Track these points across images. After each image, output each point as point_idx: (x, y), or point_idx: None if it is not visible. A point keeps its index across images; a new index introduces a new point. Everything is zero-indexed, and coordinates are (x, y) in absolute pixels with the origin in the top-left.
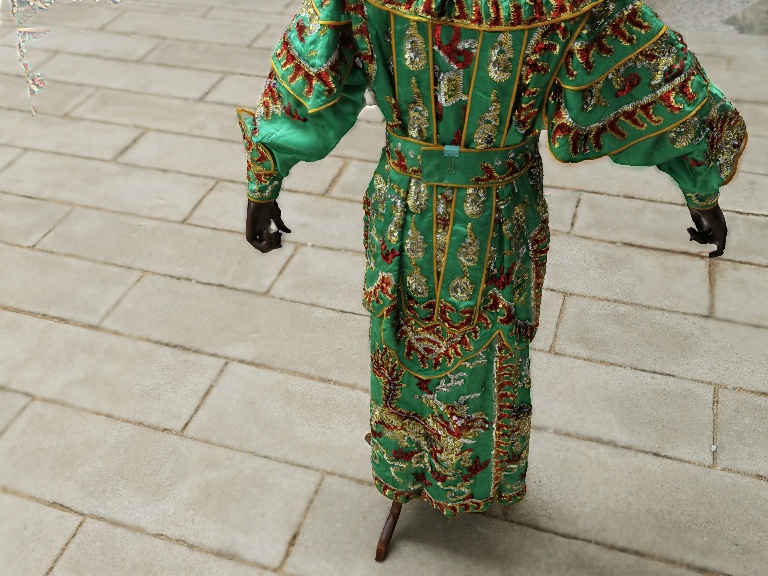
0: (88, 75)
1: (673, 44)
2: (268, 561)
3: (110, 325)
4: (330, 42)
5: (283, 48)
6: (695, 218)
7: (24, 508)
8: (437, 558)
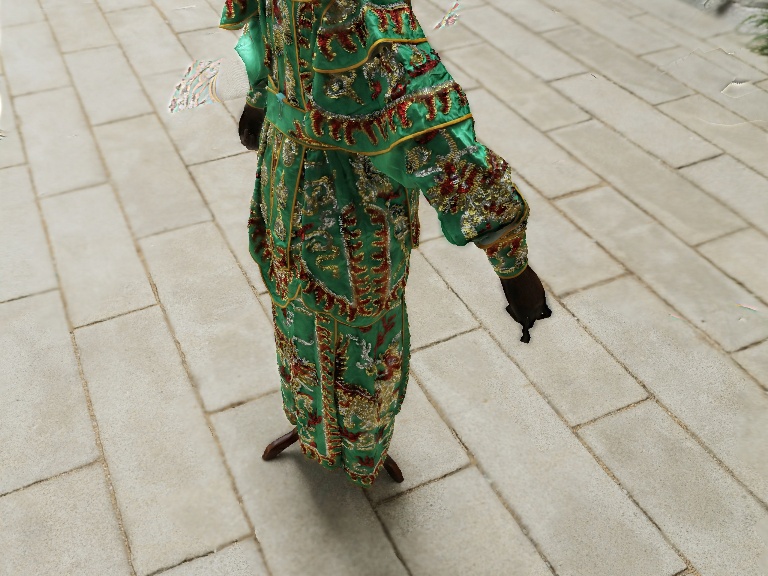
0: (489, 29)
1: (403, 64)
2: (208, 403)
3: None
4: None
5: None
6: None
7: (139, 276)
8: (298, 488)
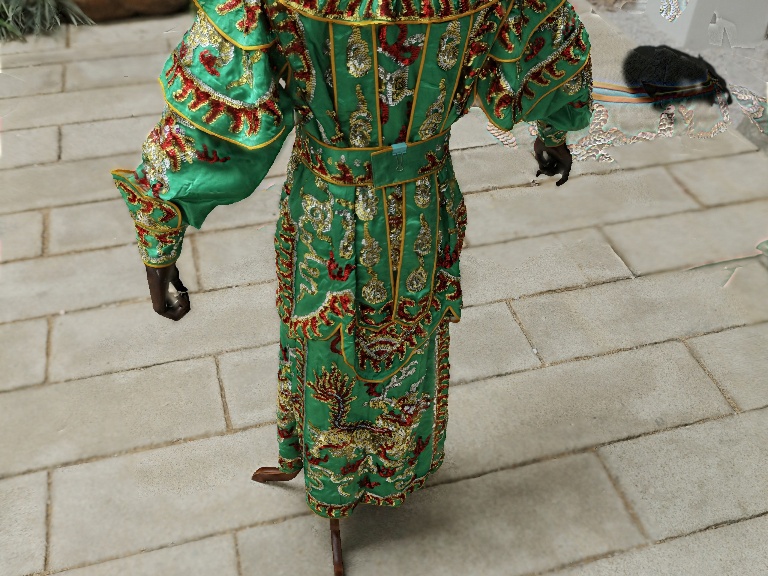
0: None
1: (565, 5)
2: None
3: None
4: (267, 67)
5: (186, 87)
6: (540, 156)
7: None
8: (388, 552)
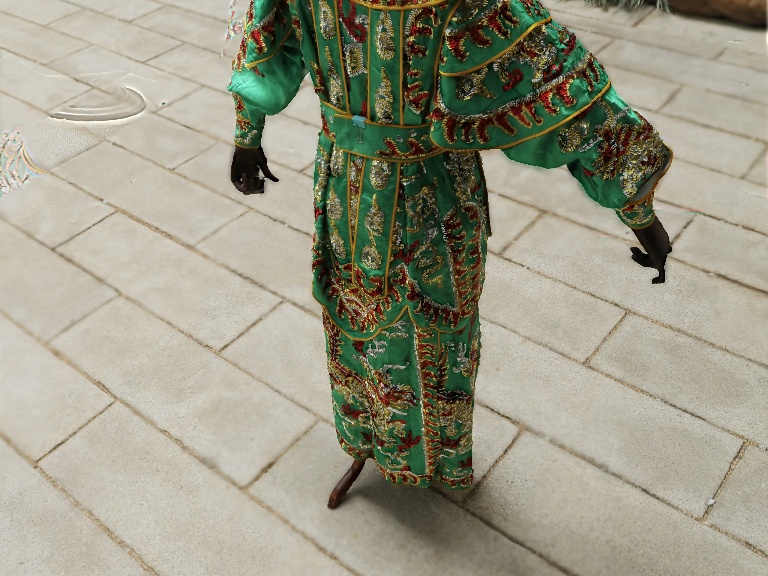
0: None
1: (553, 44)
2: (239, 479)
3: (203, 248)
4: (265, 4)
5: (250, 7)
6: None
7: (76, 380)
8: (382, 521)
